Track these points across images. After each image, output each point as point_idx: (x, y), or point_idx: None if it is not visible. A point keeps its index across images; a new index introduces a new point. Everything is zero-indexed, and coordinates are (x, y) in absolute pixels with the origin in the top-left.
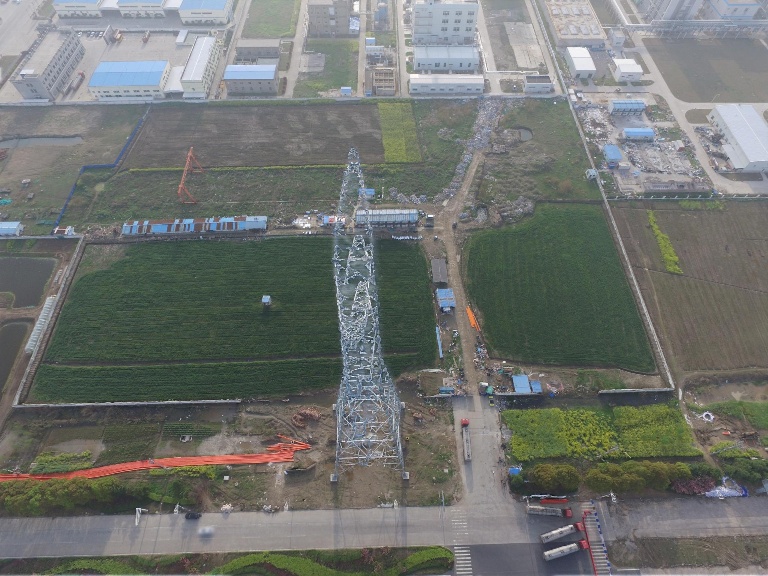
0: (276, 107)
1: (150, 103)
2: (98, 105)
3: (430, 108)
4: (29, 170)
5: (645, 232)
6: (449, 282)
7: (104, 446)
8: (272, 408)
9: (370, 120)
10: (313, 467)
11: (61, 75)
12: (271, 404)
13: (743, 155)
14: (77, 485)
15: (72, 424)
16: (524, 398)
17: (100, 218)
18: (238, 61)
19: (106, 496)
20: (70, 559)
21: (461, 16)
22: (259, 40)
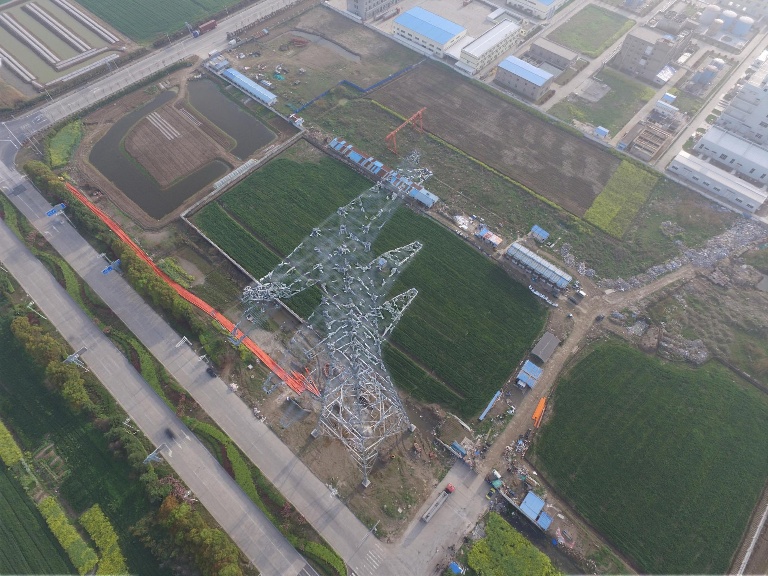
0: (525, 112)
1: (427, 56)
2: (391, 39)
3: (676, 194)
4: (310, 63)
5: None
6: (547, 363)
7: (204, 282)
8: None
9: (602, 171)
10: (309, 412)
11: (383, 3)
12: None
13: None
14: (168, 292)
15: (200, 253)
16: (525, 519)
17: (325, 124)
18: (526, 56)
19: (177, 314)
20: (133, 335)
21: None
22: (558, 46)
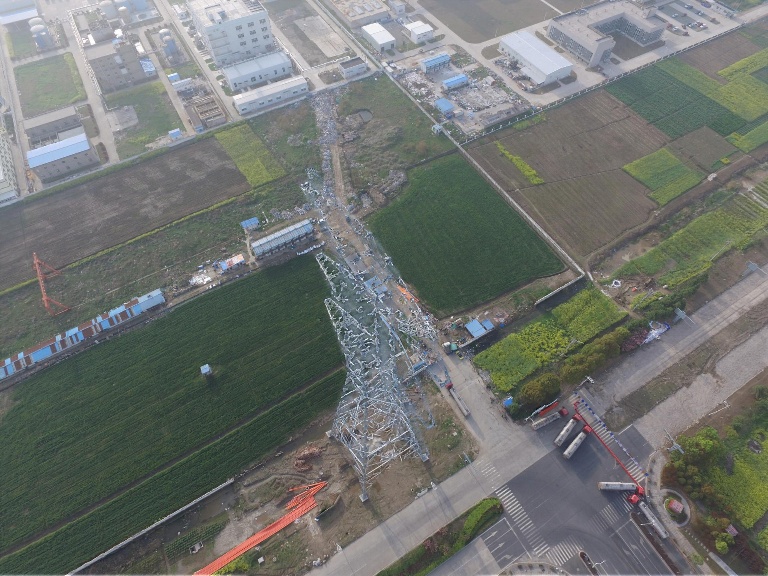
0: (107, 176)
1: None
2: None
3: (268, 122)
4: None
5: (501, 160)
6: None
7: None
8: (269, 469)
9: (215, 154)
10: (339, 499)
11: None
12: (266, 465)
13: (539, 71)
14: None
15: None
16: (483, 339)
17: None
18: (35, 144)
19: None
20: None
21: (254, 26)
22: (49, 114)
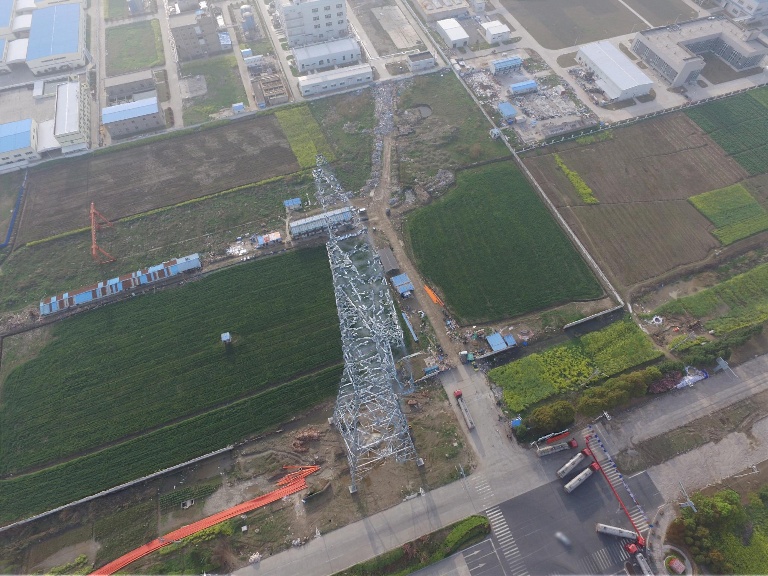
0: (170, 140)
1: (25, 168)
2: None
3: (328, 106)
4: None
5: (557, 174)
6: (400, 268)
7: (98, 544)
8: (268, 443)
9: (272, 131)
10: (329, 486)
11: None
12: (266, 439)
13: (615, 86)
14: None
15: (53, 534)
16: (502, 354)
17: (9, 305)
18: (112, 102)
19: None
20: None
21: (330, 10)
22: (128, 75)
